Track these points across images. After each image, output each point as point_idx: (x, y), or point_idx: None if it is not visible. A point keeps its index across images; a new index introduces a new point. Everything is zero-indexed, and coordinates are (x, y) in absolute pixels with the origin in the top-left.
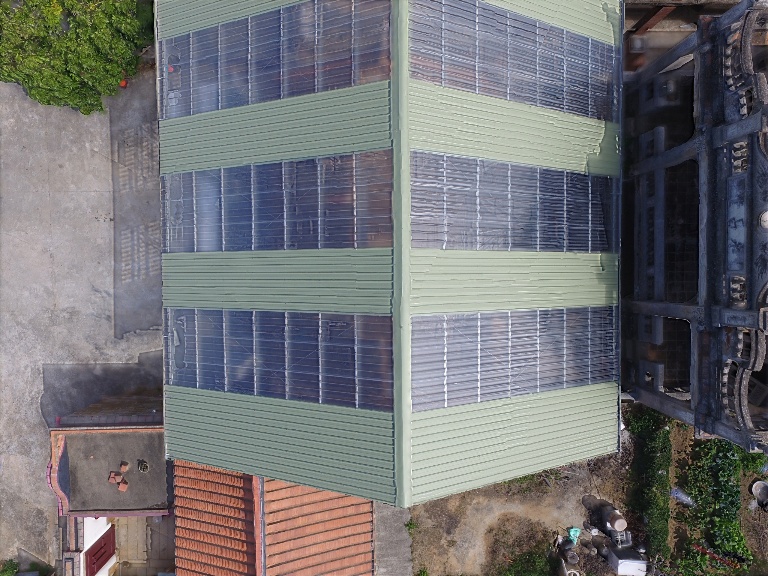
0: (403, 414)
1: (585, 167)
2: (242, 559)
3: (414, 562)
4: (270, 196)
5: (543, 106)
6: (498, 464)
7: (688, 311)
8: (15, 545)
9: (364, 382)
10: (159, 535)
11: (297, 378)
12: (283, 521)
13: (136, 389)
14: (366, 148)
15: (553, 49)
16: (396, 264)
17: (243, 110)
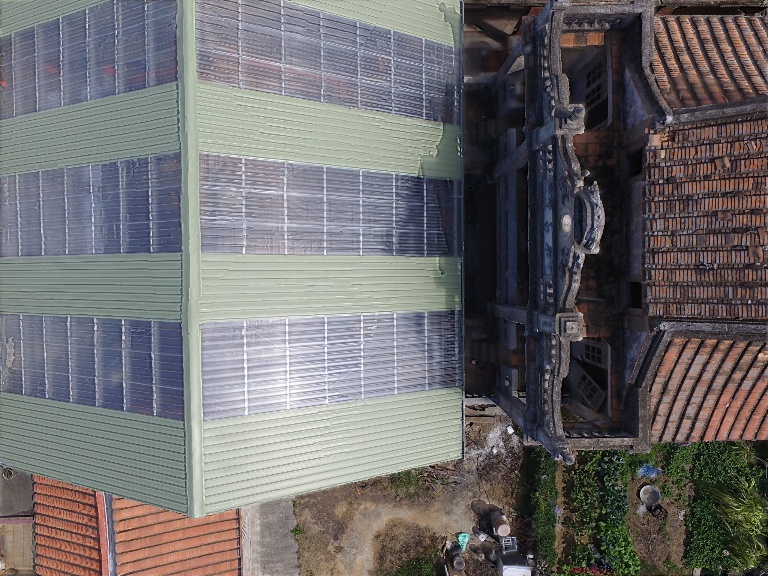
0: (192, 422)
1: (419, 169)
2: (95, 567)
3: (300, 568)
4: (80, 199)
5: (366, 108)
6: (313, 472)
7: (523, 315)
8: None
9: (160, 389)
10: None
11: (105, 385)
12: (136, 529)
13: None
14: (159, 151)
15: (378, 50)
16: (184, 269)
17: (57, 112)
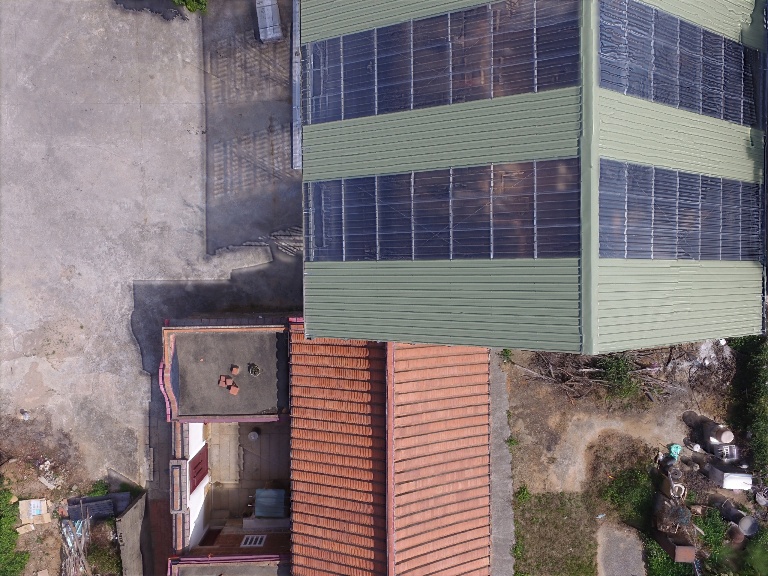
0: (592, 257)
1: (739, 36)
2: (367, 455)
3: (514, 479)
4: (433, 51)
5: None
6: (667, 326)
7: None
8: (105, 465)
9: (544, 230)
10: (252, 455)
11: (463, 236)
12: (409, 415)
13: (229, 306)
14: None
15: None
16: (585, 102)
17: None
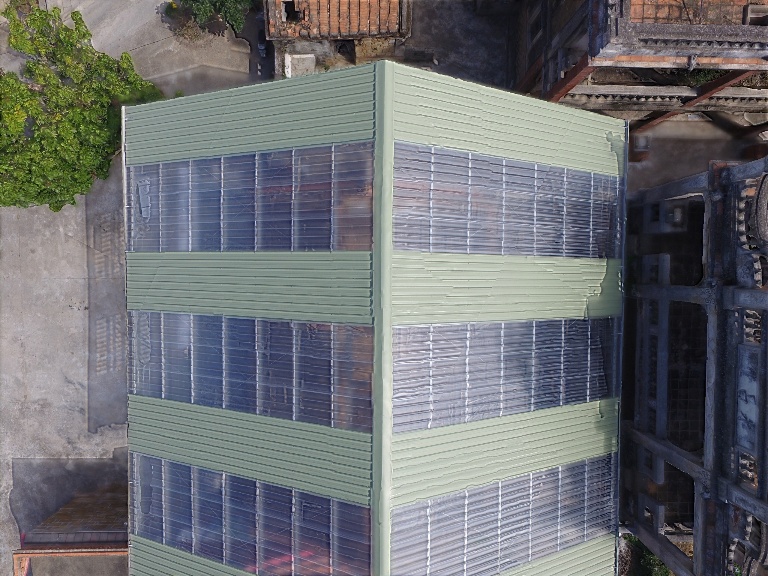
0: None
1: (585, 311)
2: None
3: None
4: (242, 354)
5: (540, 254)
6: None
7: (692, 468)
8: None
9: (339, 573)
10: None
11: (268, 554)
12: None
13: (110, 486)
14: (345, 321)
15: (552, 191)
16: (375, 454)
17: (214, 256)
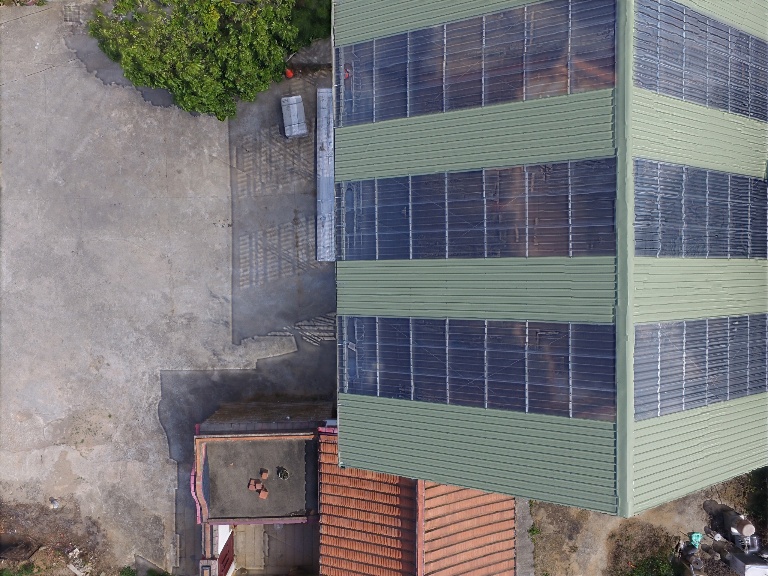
0: (627, 424)
1: (765, 174)
2: (396, 567)
3: (536, 568)
4: (468, 204)
5: (733, 113)
6: (697, 472)
7: None
8: (133, 552)
9: (580, 391)
10: (276, 542)
11: (498, 387)
12: (438, 529)
13: (254, 395)
14: (584, 156)
15: (741, 56)
16: (620, 273)
17: (436, 118)
